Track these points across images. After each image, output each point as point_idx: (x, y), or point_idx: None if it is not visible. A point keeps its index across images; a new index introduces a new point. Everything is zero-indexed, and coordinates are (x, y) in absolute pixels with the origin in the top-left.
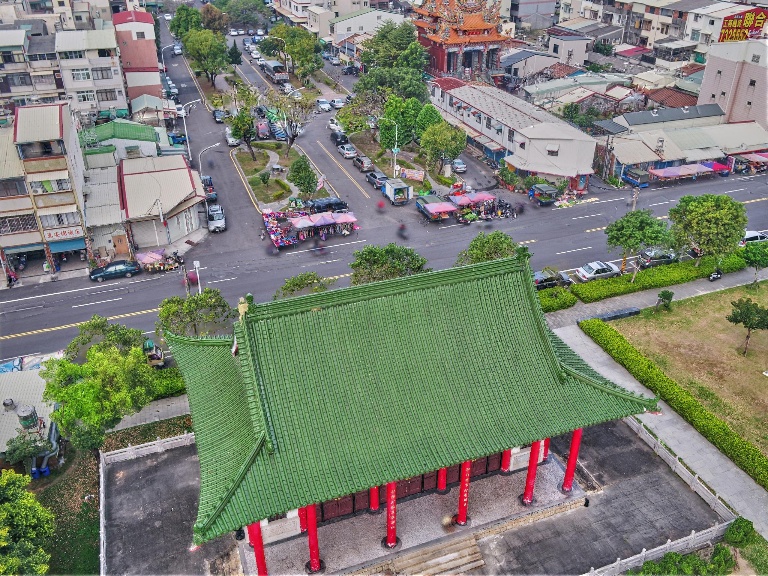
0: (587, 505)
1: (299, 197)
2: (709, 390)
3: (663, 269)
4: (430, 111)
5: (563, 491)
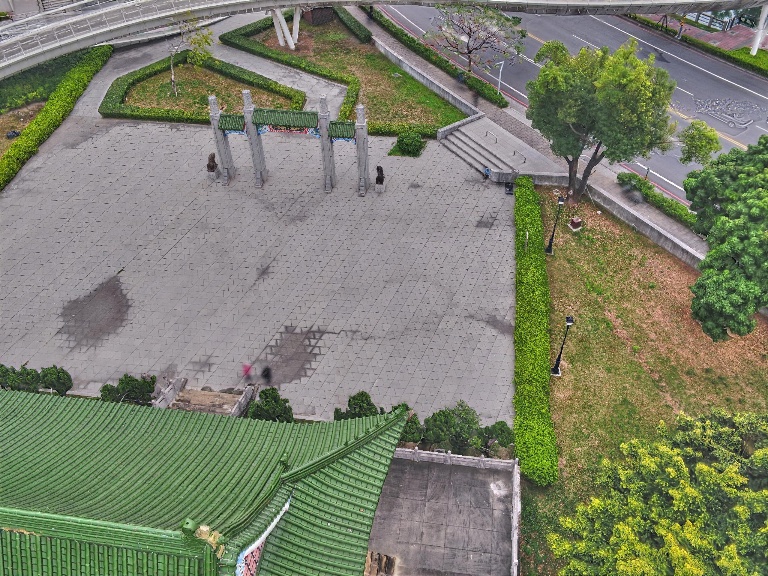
0: None
1: None
2: None
3: None
4: None
5: None
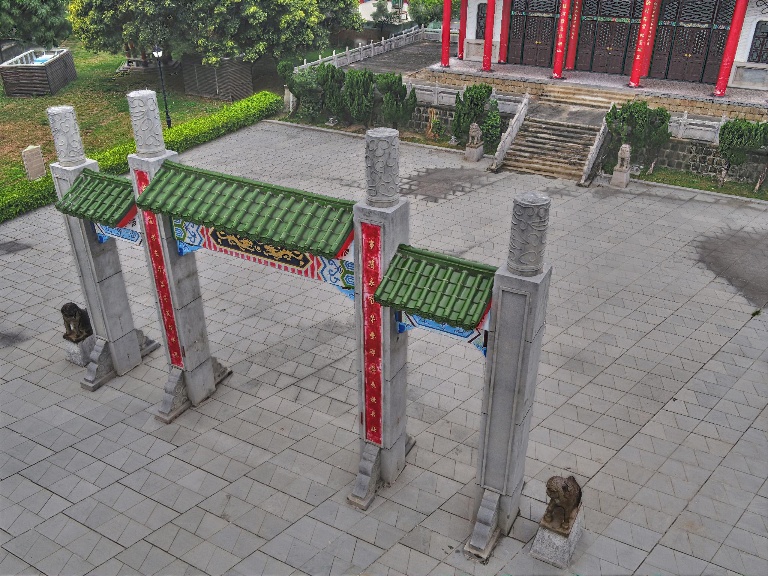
0: None
1: None
2: None
3: None
4: None
5: None
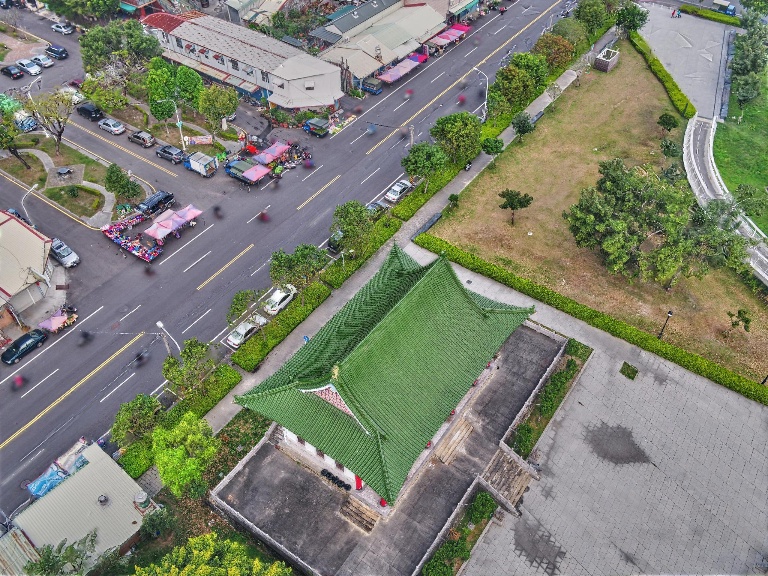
0: (499, 368)
1: (116, 199)
2: (508, 259)
3: (437, 173)
4: (189, 74)
5: (486, 367)
